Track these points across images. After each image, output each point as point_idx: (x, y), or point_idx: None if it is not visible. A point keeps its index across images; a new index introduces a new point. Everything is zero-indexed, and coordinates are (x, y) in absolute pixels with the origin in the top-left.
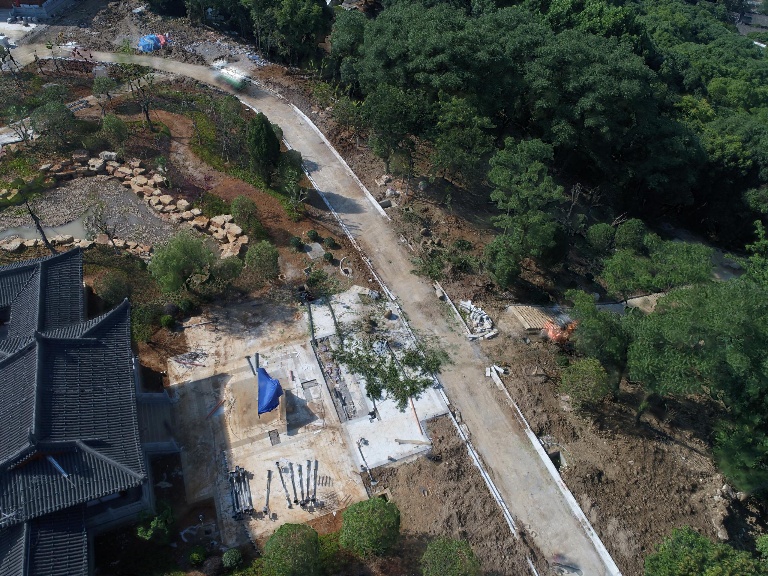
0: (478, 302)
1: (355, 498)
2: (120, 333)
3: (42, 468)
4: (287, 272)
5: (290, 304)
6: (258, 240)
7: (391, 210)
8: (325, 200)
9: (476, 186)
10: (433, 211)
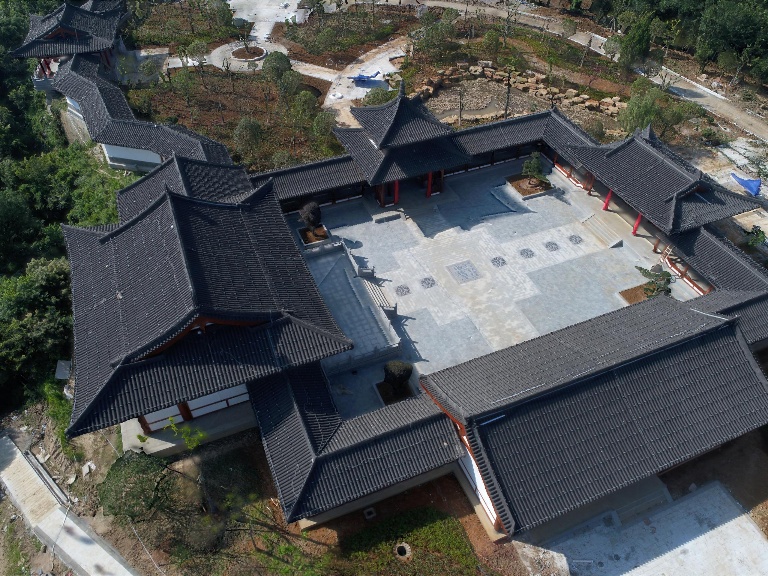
0: None
1: None
2: (659, 143)
3: (695, 199)
4: (683, 131)
5: (703, 148)
6: None
7: (725, 95)
8: (672, 89)
9: (761, 85)
10: None
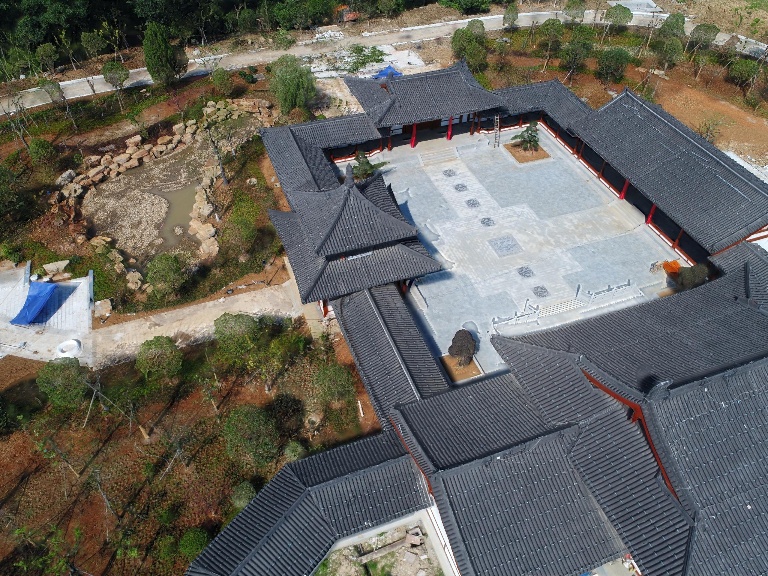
0: (315, 35)
1: (439, 66)
2: None
3: None
4: None
5: None
6: (239, 96)
7: (219, 53)
8: (197, 74)
9: None
10: (224, 42)
